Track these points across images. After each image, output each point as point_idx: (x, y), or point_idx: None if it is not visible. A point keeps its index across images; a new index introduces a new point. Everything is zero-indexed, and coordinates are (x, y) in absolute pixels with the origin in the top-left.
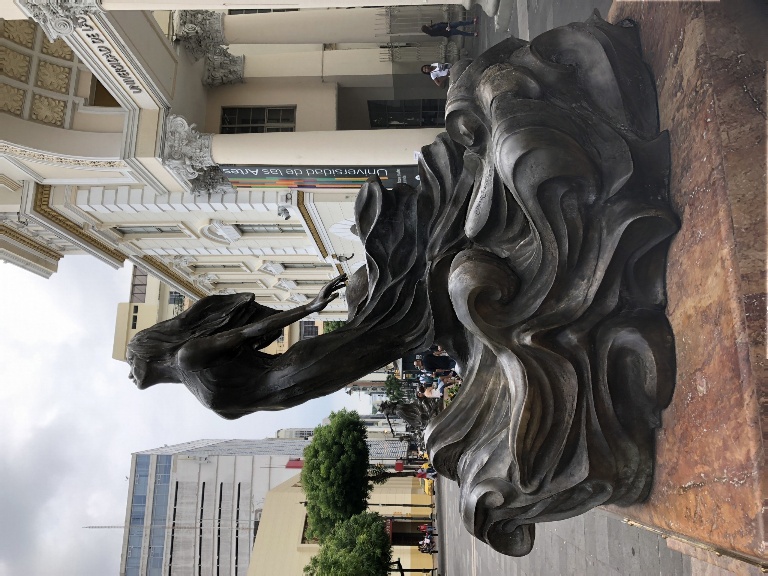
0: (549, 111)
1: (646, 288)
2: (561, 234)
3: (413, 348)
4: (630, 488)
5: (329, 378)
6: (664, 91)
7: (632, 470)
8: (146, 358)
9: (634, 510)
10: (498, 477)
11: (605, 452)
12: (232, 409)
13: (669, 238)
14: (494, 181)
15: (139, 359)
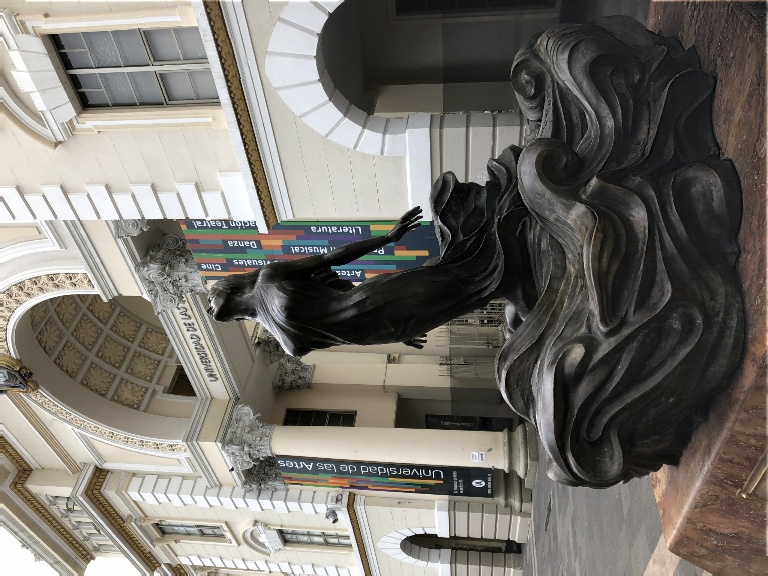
0: (593, 28)
1: (698, 147)
2: (614, 106)
3: (483, 288)
4: (722, 328)
5: (401, 294)
6: (685, 30)
7: (720, 303)
8: (228, 289)
9: (736, 389)
10: (576, 335)
11: (686, 279)
12: (302, 324)
13: (710, 100)
14: (553, 106)
15: (221, 291)
